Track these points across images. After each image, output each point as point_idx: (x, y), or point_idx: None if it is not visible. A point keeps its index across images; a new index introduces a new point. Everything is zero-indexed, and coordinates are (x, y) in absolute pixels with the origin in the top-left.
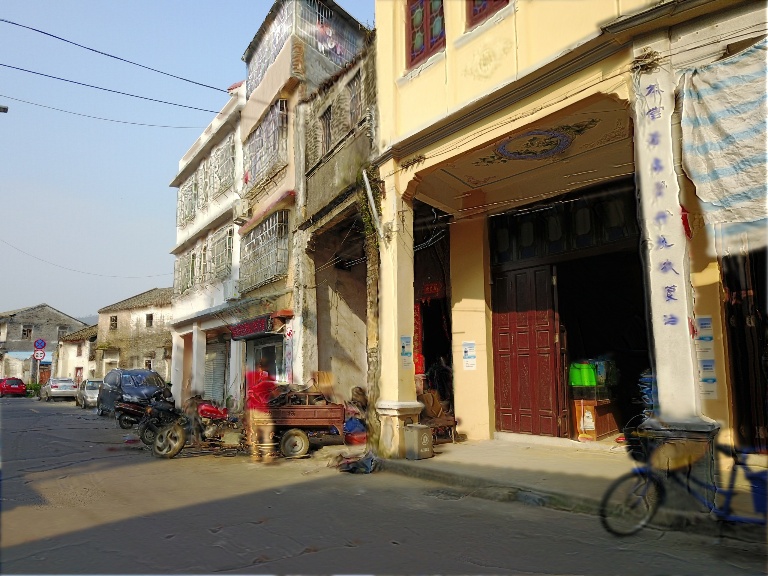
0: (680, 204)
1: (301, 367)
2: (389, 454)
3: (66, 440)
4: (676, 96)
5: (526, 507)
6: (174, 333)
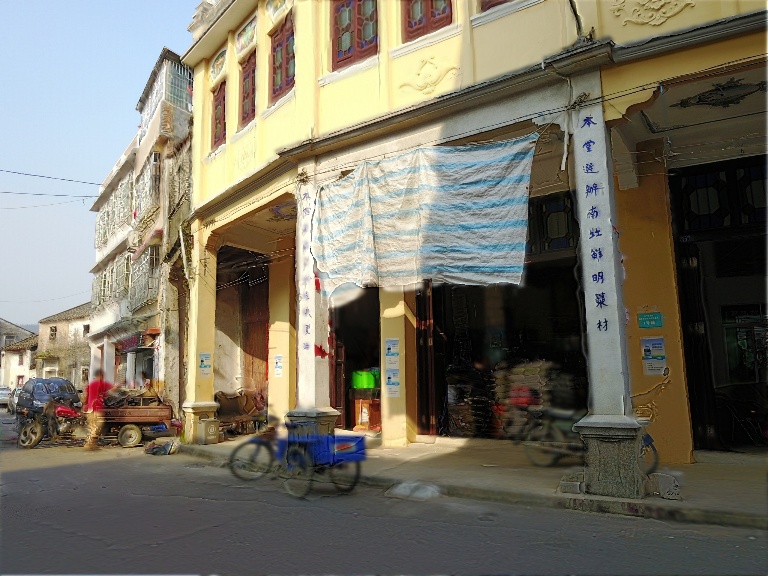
0: (313, 272)
1: (163, 376)
2: (188, 441)
3: None
4: None
5: (230, 470)
6: (92, 345)
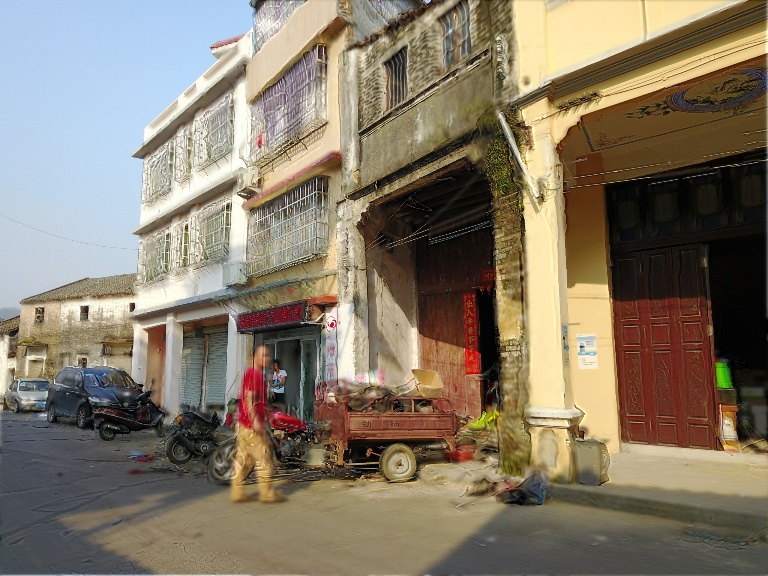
0: None
1: (352, 365)
2: (552, 477)
3: (47, 457)
4: None
5: None
6: (137, 326)
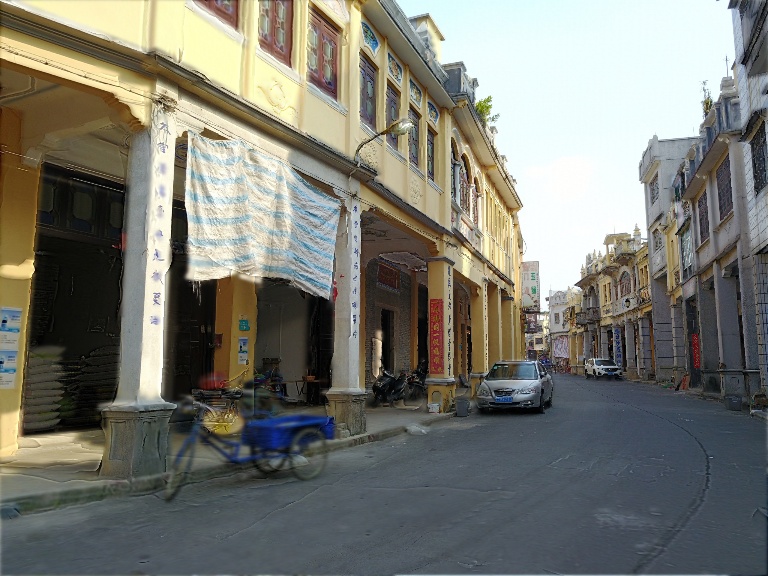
0: (172, 230)
1: None
2: None
3: None
4: (181, 145)
5: (19, 520)
6: None
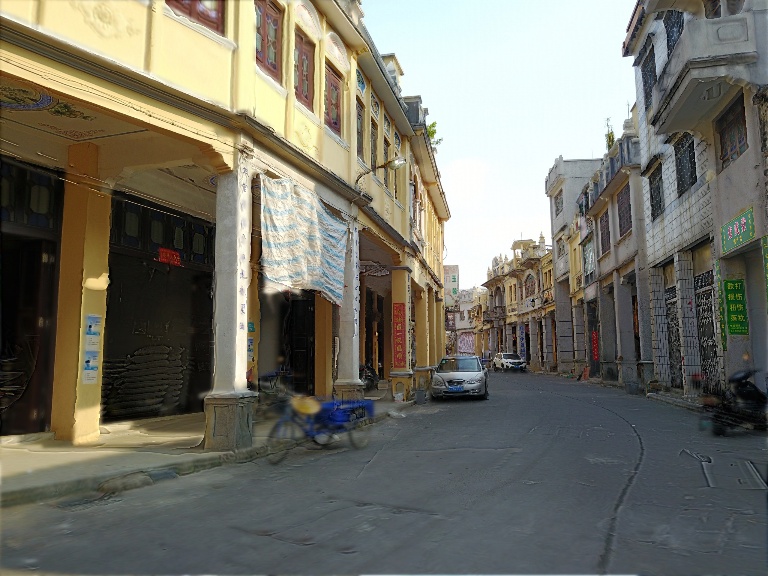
0: (251, 253)
1: None
2: None
3: None
4: (256, 185)
5: (181, 479)
6: None
